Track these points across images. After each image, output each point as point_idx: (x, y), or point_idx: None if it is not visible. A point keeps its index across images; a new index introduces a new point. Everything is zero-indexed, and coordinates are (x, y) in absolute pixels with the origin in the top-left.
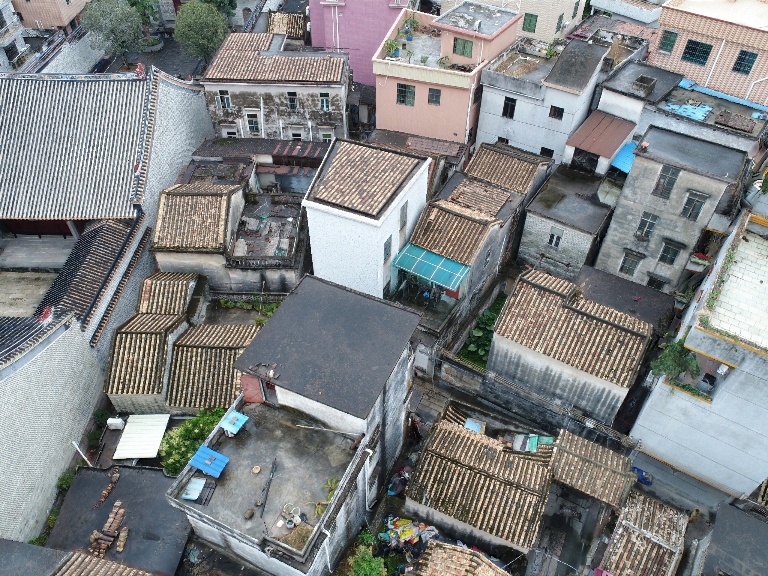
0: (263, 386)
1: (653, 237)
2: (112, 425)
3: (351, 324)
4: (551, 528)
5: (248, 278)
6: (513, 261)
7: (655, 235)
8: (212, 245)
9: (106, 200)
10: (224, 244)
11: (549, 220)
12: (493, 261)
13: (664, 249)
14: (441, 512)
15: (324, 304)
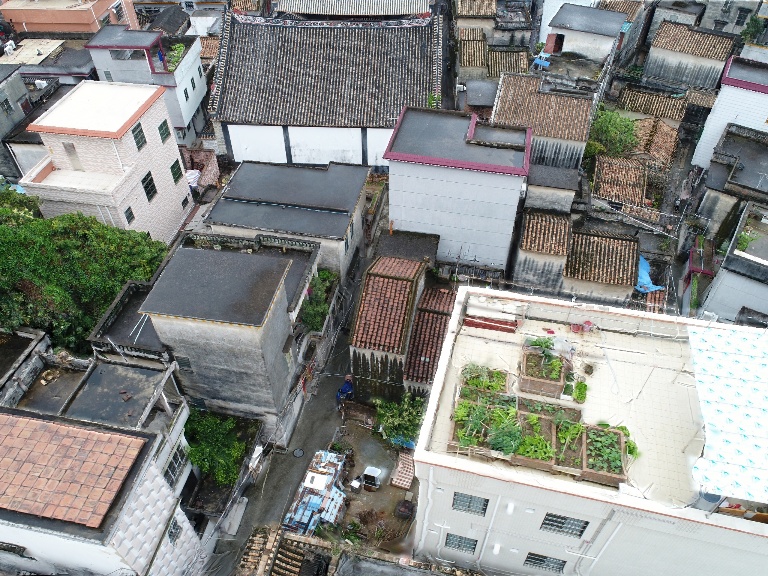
0: (554, 44)
1: (733, 9)
2: (458, 87)
3: (596, 15)
4: (682, 142)
5: (504, 37)
6: (643, 45)
7: (734, 7)
8: (490, 14)
9: (412, 4)
10: (496, 14)
11: (670, 10)
12: (636, 36)
13: (739, 16)
14: (634, 112)
15: (579, 10)
